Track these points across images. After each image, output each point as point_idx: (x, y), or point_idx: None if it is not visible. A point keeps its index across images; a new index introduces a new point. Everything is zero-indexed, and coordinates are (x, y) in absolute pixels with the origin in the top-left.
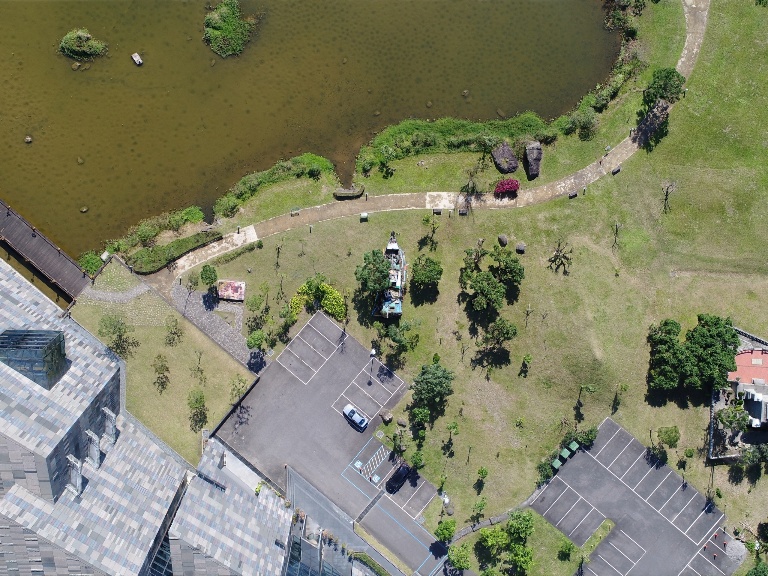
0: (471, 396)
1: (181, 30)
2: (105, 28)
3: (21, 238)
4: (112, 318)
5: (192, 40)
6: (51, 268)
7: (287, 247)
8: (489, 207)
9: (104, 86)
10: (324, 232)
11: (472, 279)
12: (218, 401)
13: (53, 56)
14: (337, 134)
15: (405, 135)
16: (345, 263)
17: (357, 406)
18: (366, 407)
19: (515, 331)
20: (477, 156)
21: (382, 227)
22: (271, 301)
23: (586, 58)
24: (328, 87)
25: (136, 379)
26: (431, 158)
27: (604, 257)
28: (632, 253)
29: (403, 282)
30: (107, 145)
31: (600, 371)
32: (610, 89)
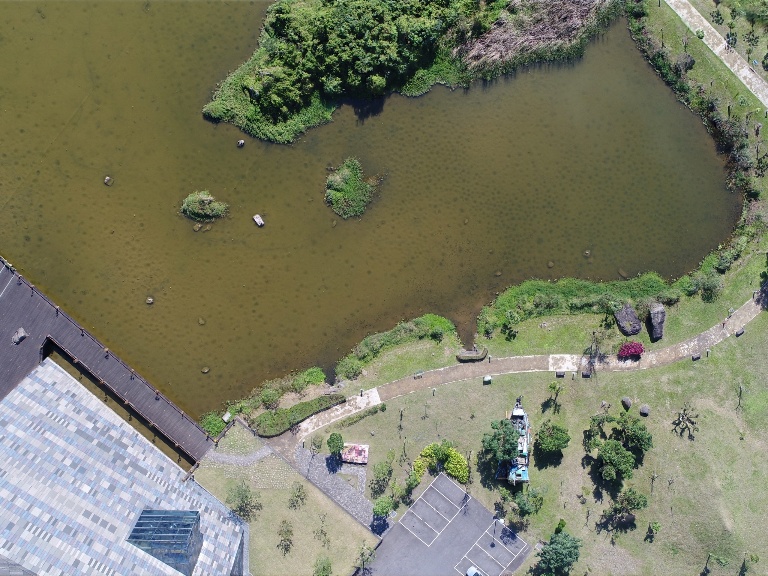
0: (596, 560)
1: (302, 191)
2: (226, 189)
3: (144, 401)
4: (240, 487)
5: (313, 201)
6: (174, 431)
7: (410, 410)
8: (612, 369)
9: (225, 247)
10: (447, 395)
11: (600, 448)
12: (341, 564)
13: (174, 217)
14: (458, 294)
15: (527, 296)
16: (468, 426)
17: (480, 568)
18: (489, 569)
19: (645, 502)
20: (600, 317)
21: (505, 390)
22: (394, 463)
23: (708, 218)
24: (449, 248)
25: (259, 542)
26: (553, 320)
27: (728, 420)
28: (756, 415)
29: (527, 445)
30: (228, 306)
31: (729, 541)
32: (734, 252)
